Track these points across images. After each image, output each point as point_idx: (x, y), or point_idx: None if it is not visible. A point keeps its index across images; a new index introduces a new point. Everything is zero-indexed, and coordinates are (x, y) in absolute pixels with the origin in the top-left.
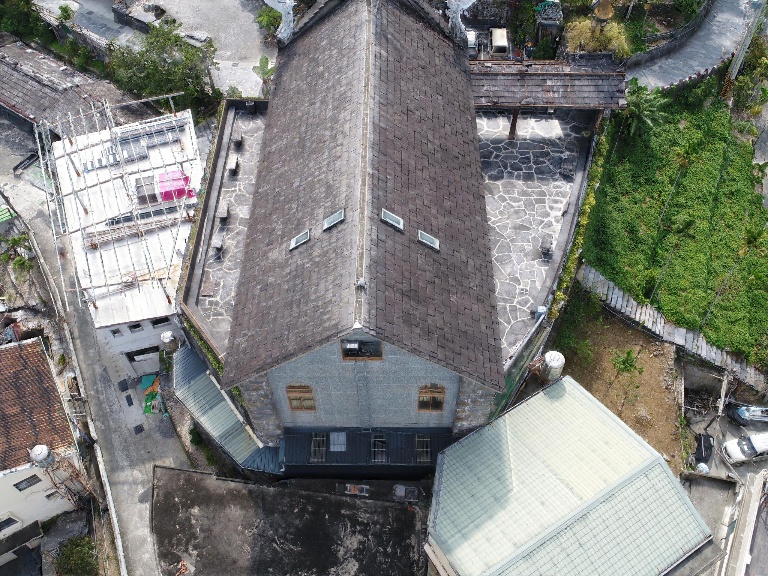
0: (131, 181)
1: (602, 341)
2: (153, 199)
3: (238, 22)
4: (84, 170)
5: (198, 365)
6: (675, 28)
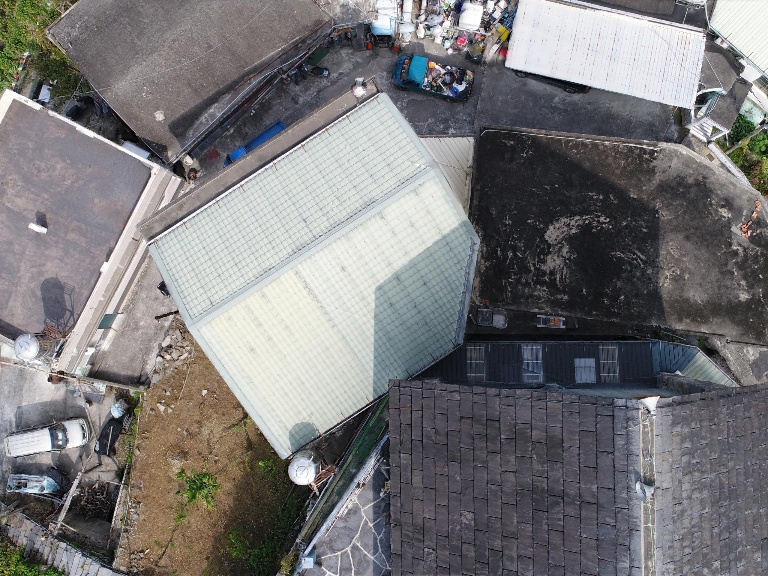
0: None
1: (211, 569)
2: None
3: None
4: None
5: None
6: None
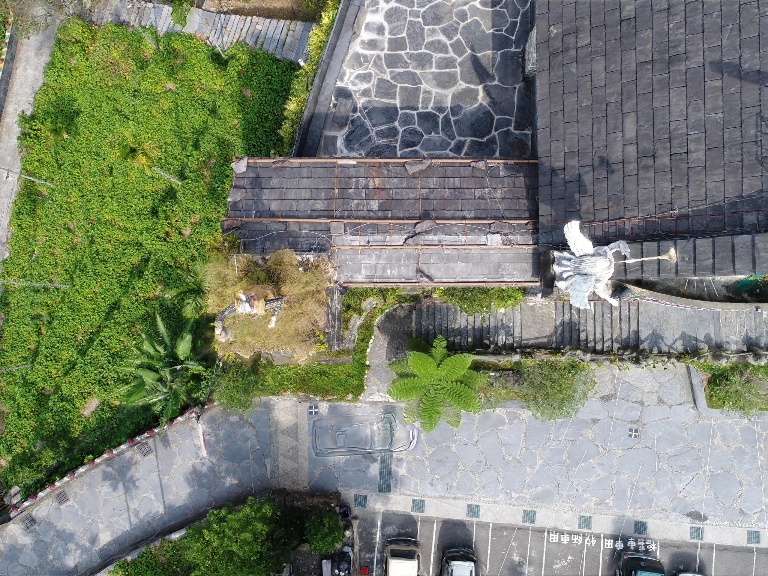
0: None
1: None
2: None
3: None
4: None
5: None
6: None
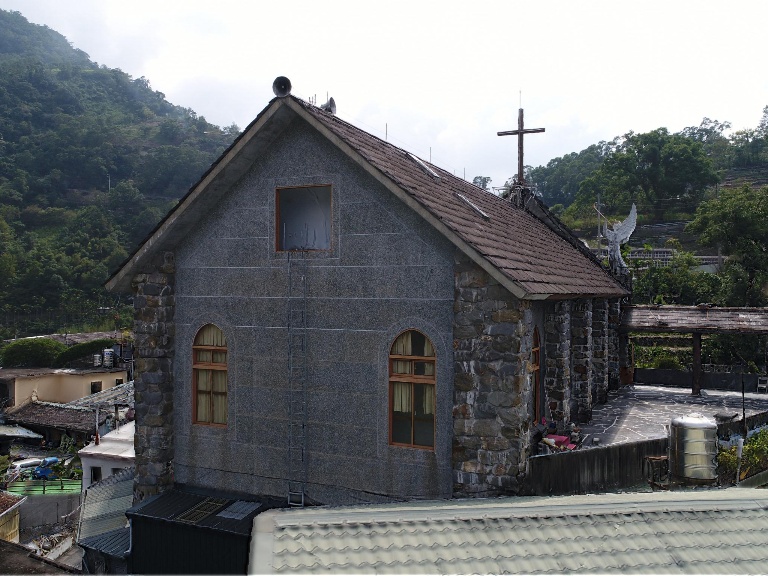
0: None
1: None
2: None
3: None
4: None
5: None
6: None
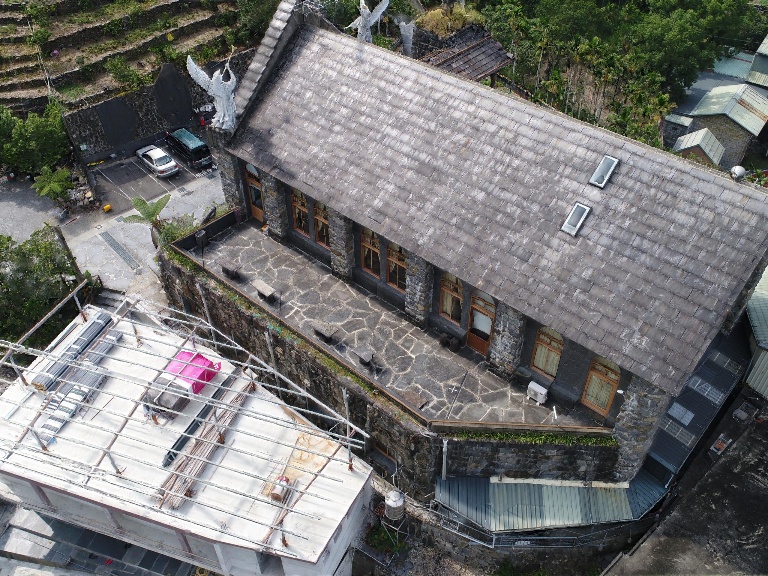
0: (125, 408)
1: None
2: (185, 401)
3: (1, 216)
4: (47, 442)
5: (475, 485)
6: (398, 36)
